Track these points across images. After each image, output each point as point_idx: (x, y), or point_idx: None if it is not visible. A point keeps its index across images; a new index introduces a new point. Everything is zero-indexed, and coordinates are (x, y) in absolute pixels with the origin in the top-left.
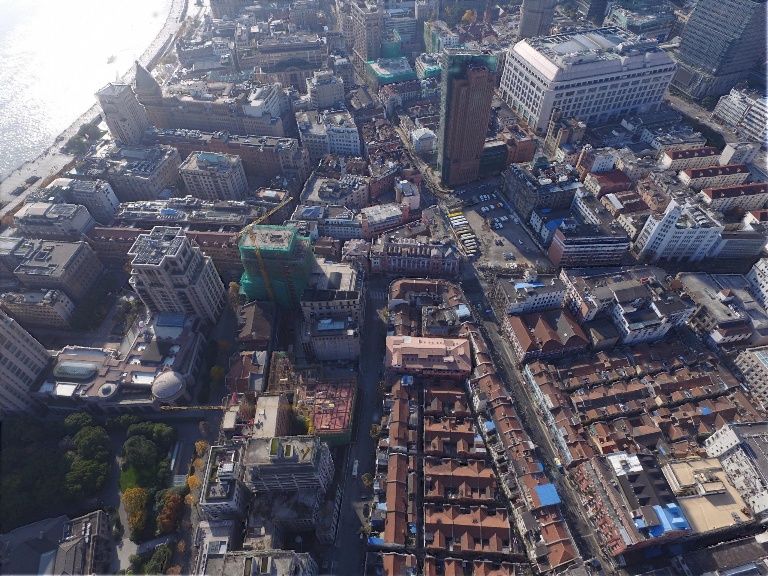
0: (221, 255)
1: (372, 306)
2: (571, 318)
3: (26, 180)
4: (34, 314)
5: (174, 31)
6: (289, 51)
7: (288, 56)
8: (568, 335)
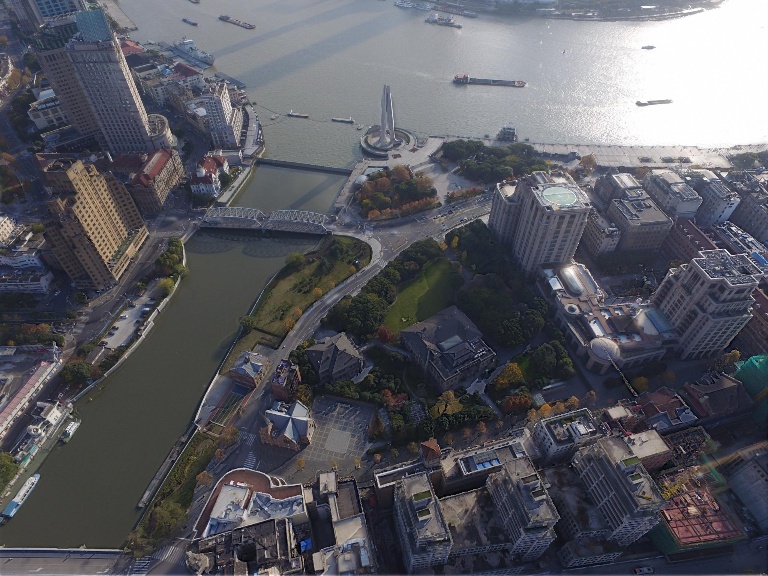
0: (757, 327)
1: None
2: None
3: (681, 157)
4: (590, 232)
5: None
6: None
7: None
8: None
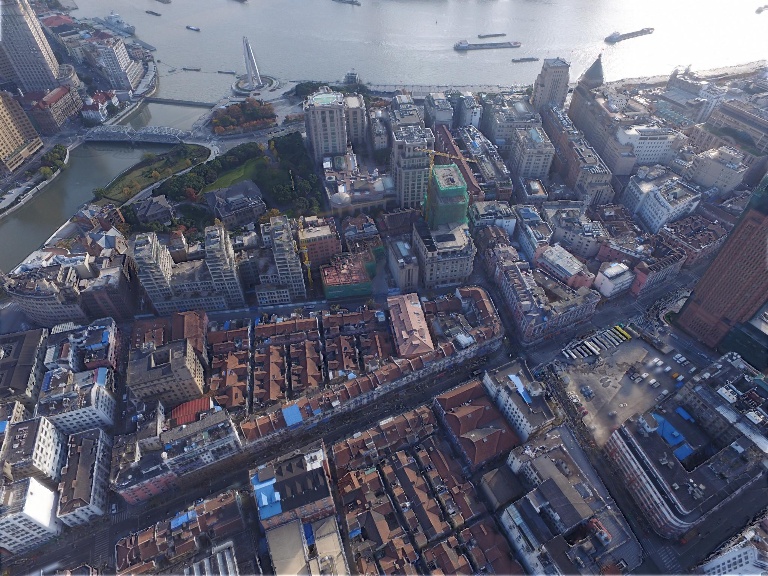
0: None
1: None
2: (501, 443)
3: (480, 92)
4: (373, 136)
5: (733, 72)
6: (746, 122)
7: (740, 126)
8: (472, 437)
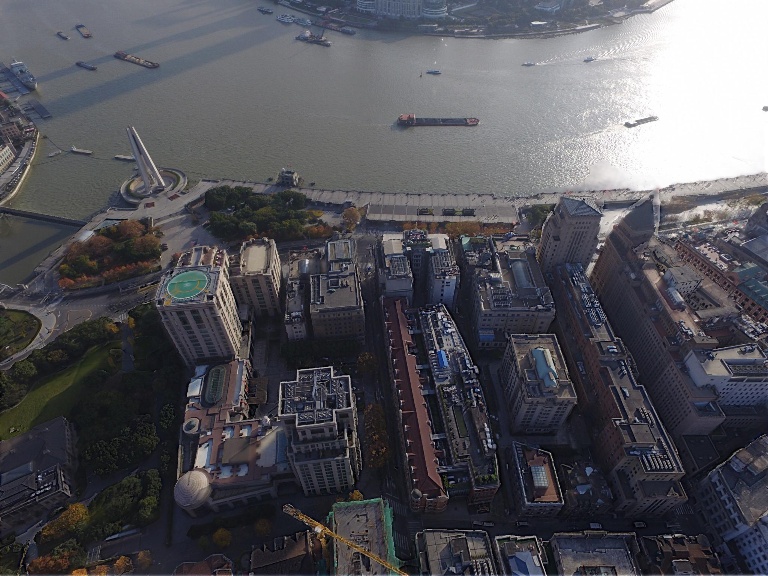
0: None
1: None
2: None
3: (465, 208)
4: None
5: None
6: None
7: None
8: None
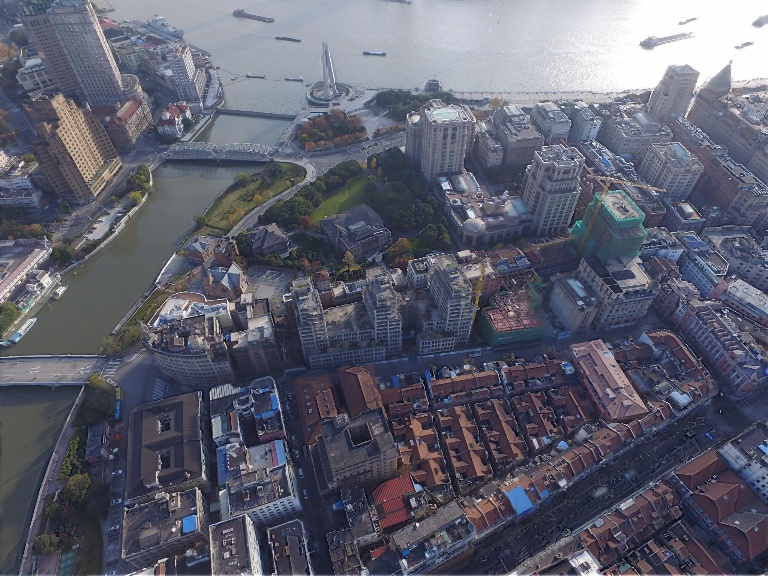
0: None
1: (632, 331)
2: None
3: (576, 99)
4: (483, 152)
5: None
6: None
7: None
8: (739, 525)
